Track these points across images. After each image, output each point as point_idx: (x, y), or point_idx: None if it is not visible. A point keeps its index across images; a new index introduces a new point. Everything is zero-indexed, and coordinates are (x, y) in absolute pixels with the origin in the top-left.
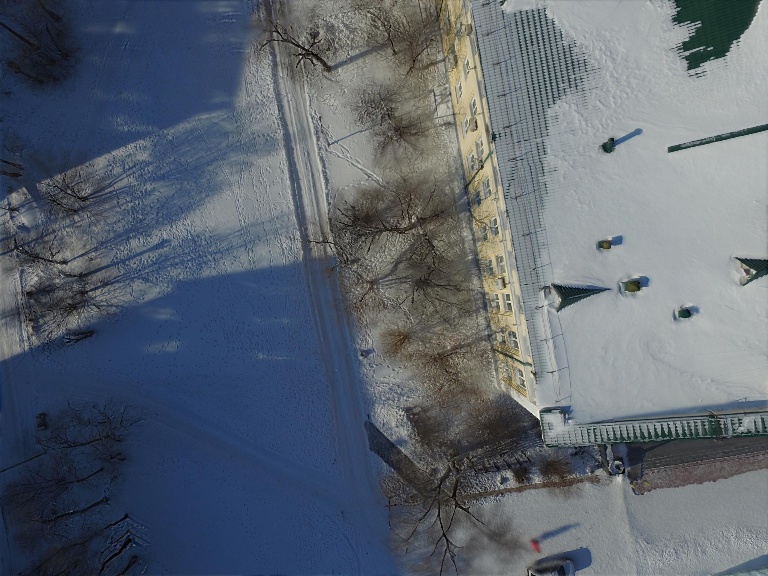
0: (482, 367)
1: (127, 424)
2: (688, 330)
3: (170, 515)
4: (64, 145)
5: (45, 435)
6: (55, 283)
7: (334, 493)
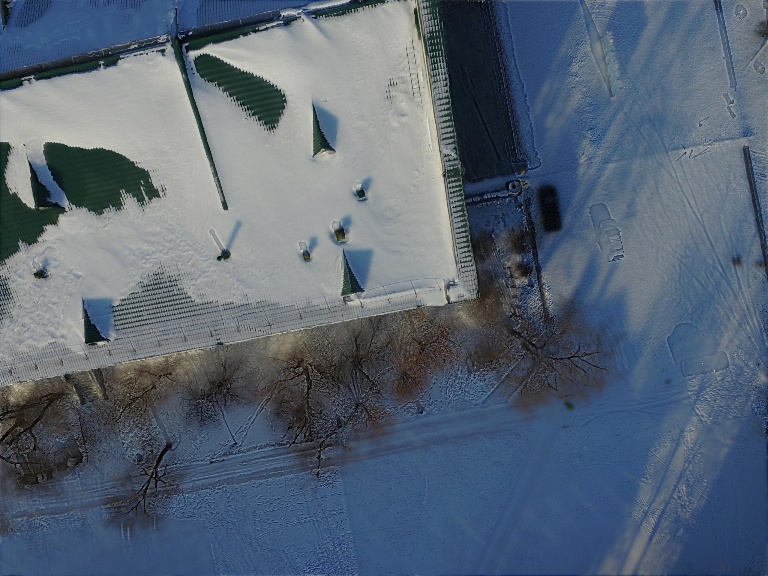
0: None
1: None
2: (375, 189)
3: None
4: None
5: None
6: None
7: (546, 435)
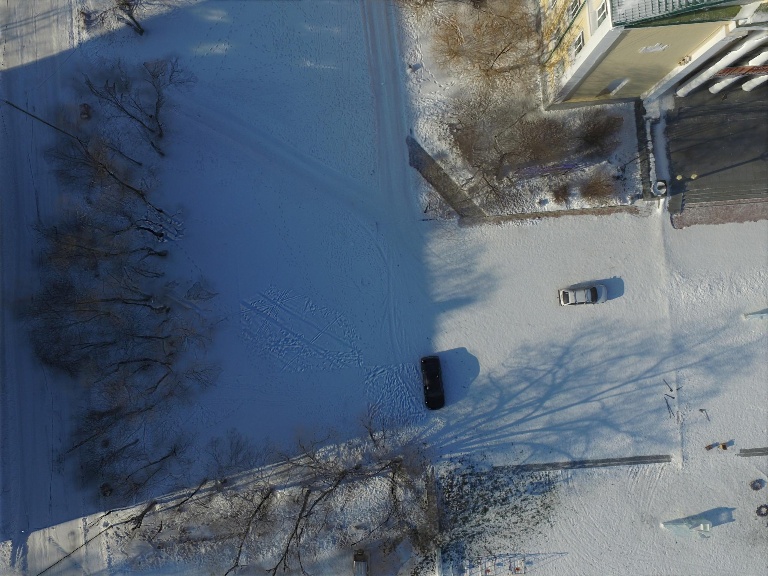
0: (529, 90)
1: (176, 81)
2: None
3: (204, 212)
4: None
5: (87, 124)
6: None
7: (370, 204)
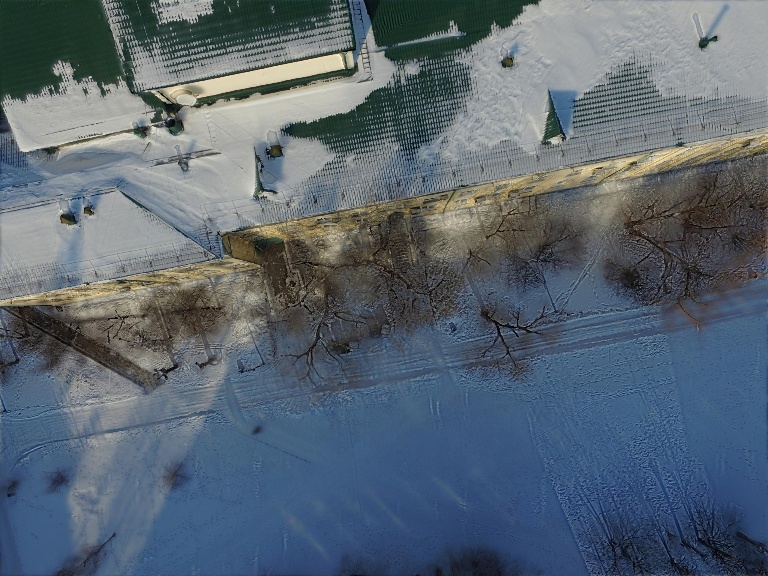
0: (761, 166)
1: None
2: None
3: None
4: (560, 563)
5: None
6: (692, 570)
7: None
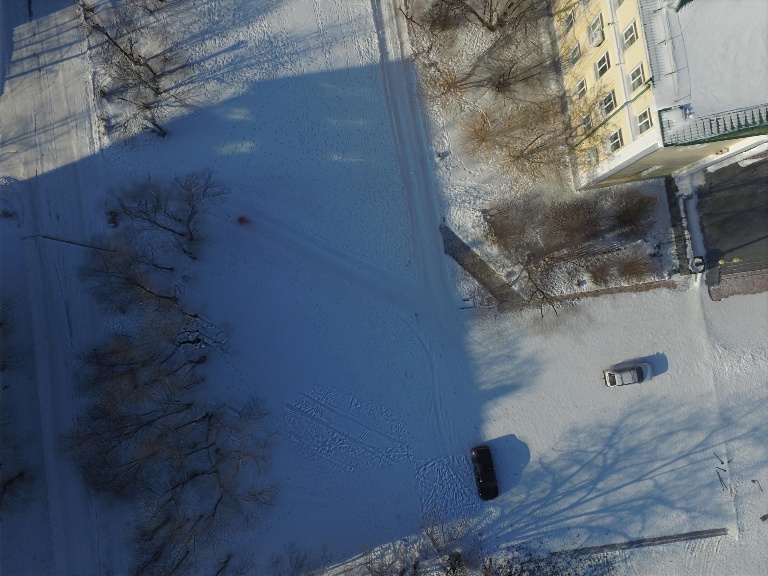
0: (559, 171)
1: (210, 195)
2: None
3: (241, 315)
4: None
5: (115, 233)
6: (128, 83)
7: (408, 296)
